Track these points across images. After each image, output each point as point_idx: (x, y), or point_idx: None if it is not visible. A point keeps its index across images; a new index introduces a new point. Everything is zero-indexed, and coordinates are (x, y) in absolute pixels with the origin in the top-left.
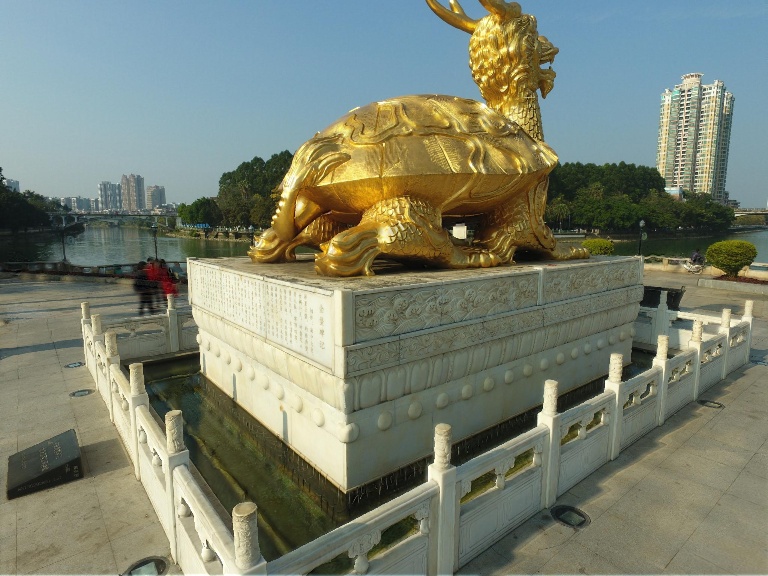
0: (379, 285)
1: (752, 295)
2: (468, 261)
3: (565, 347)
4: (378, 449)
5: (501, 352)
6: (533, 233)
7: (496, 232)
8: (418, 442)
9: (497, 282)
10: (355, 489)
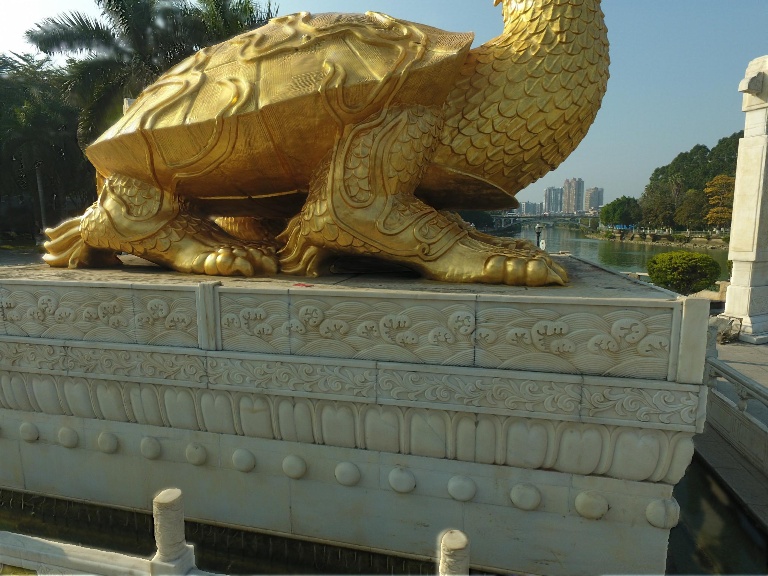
0: None
1: None
2: (191, 263)
3: (312, 450)
4: None
5: (123, 403)
6: (335, 223)
7: (291, 222)
8: (4, 467)
9: (96, 293)
10: None
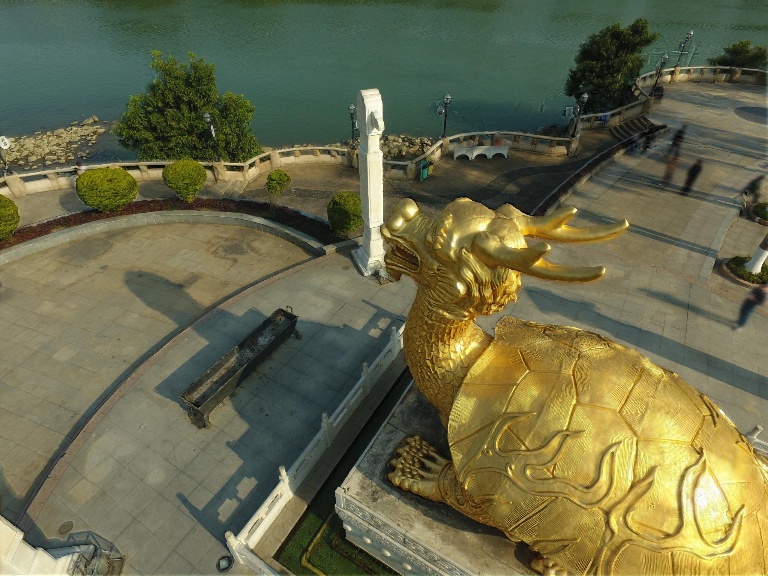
0: None
1: (73, 249)
2: None
3: None
4: None
5: None
6: None
7: None
8: None
9: None
10: None
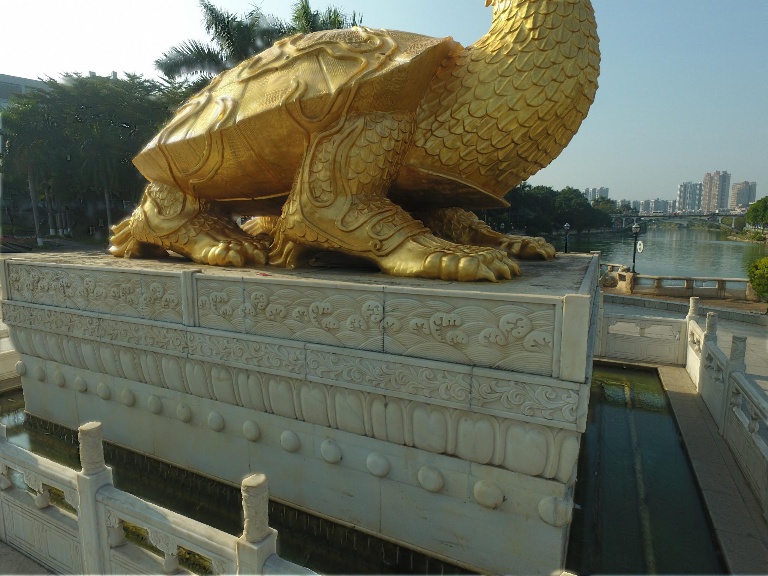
0: (51, 261)
1: None
2: None
3: (264, 418)
4: (40, 394)
5: (136, 366)
6: None
7: None
8: (67, 411)
9: (118, 277)
10: (28, 414)
